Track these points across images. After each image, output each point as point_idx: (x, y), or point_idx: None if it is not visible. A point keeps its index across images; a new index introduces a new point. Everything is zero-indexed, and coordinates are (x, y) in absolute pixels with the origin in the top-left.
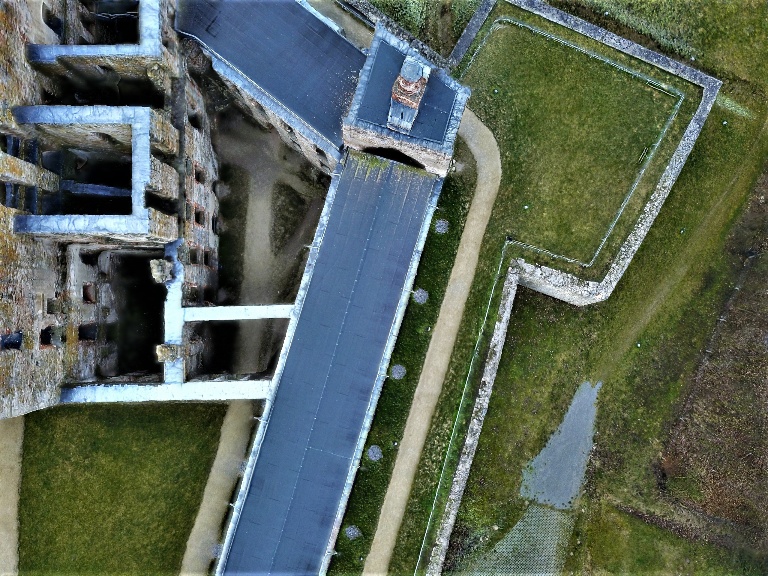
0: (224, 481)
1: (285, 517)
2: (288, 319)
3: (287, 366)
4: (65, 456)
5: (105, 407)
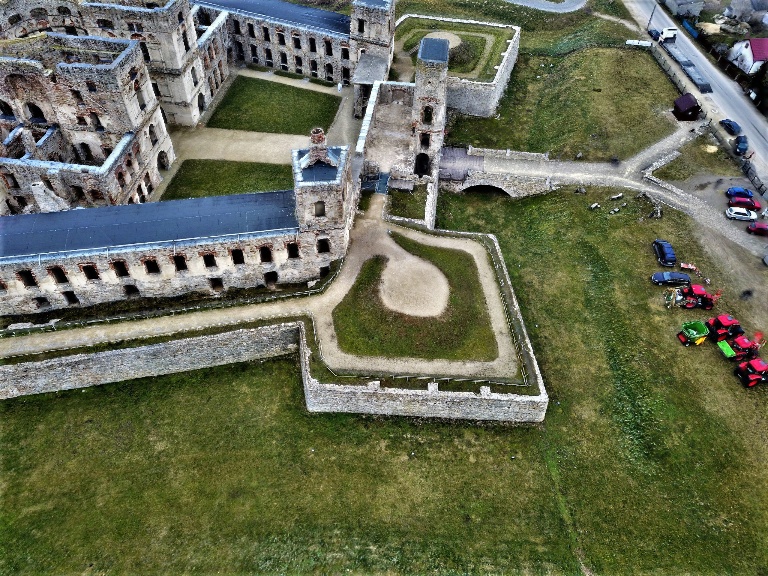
0: (273, 77)
1: (276, 8)
2: (200, 7)
3: (218, 4)
4: (237, 116)
5: (220, 105)
